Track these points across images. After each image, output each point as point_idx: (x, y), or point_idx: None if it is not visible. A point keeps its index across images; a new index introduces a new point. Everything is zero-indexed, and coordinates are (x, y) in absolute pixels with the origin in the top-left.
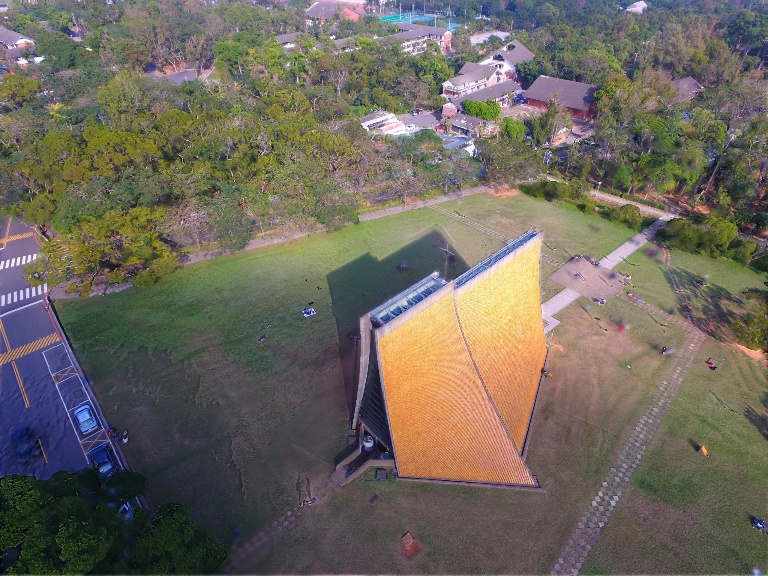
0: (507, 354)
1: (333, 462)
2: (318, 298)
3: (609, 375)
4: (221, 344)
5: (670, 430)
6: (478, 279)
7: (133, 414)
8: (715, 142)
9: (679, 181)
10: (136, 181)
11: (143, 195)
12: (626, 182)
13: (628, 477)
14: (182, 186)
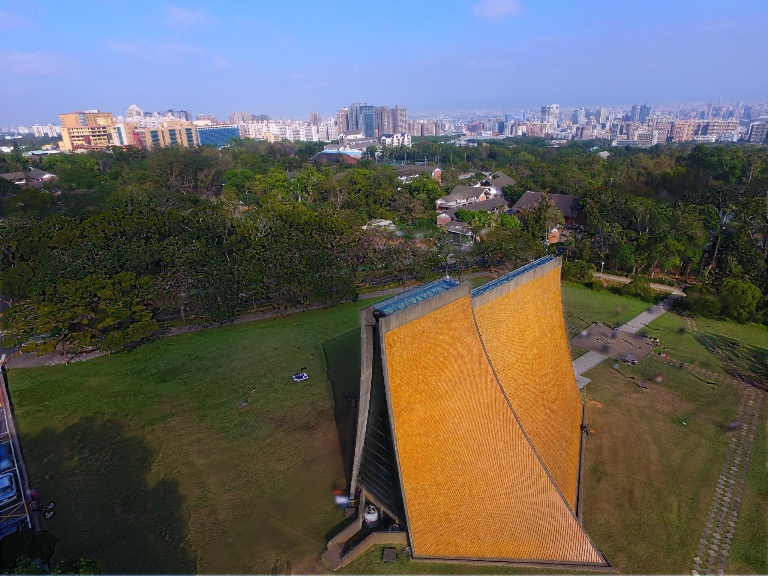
0: (538, 394)
1: (324, 540)
2: (311, 364)
3: (664, 431)
4: (194, 410)
5: (760, 492)
6: (496, 293)
7: (68, 484)
8: (710, 223)
9: (682, 261)
10: (125, 248)
11: (130, 261)
12: (630, 260)
13: (726, 550)
14: (173, 255)
